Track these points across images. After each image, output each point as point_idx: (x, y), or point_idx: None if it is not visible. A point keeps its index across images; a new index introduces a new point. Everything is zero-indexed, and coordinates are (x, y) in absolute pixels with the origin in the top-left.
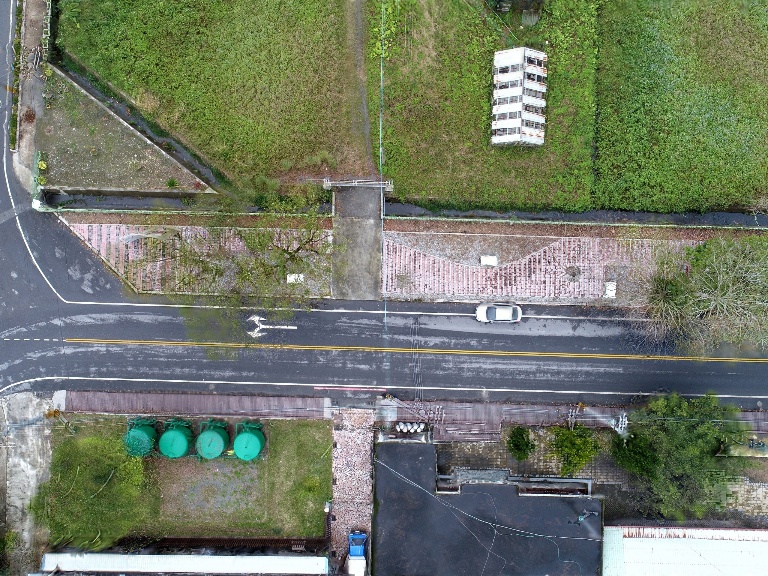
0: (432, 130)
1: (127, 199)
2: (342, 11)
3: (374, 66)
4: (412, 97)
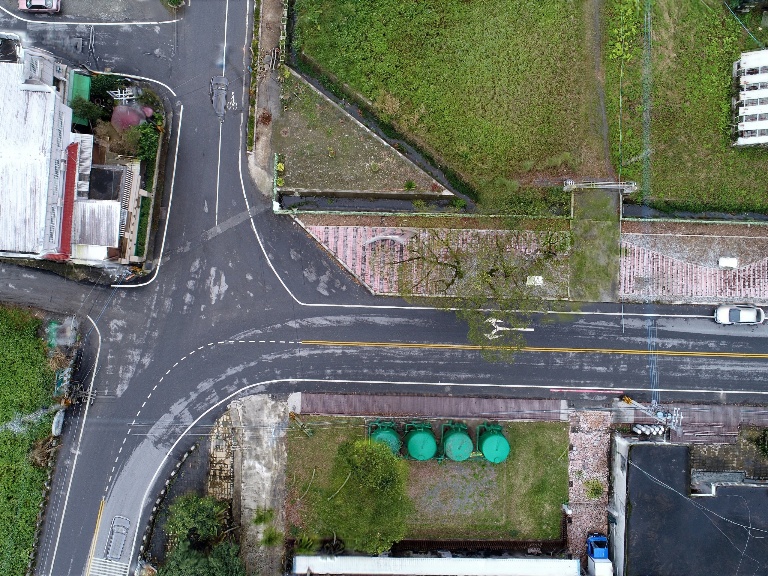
0: (671, 132)
1: (358, 201)
2: (581, 12)
3: (613, 67)
4: (653, 98)
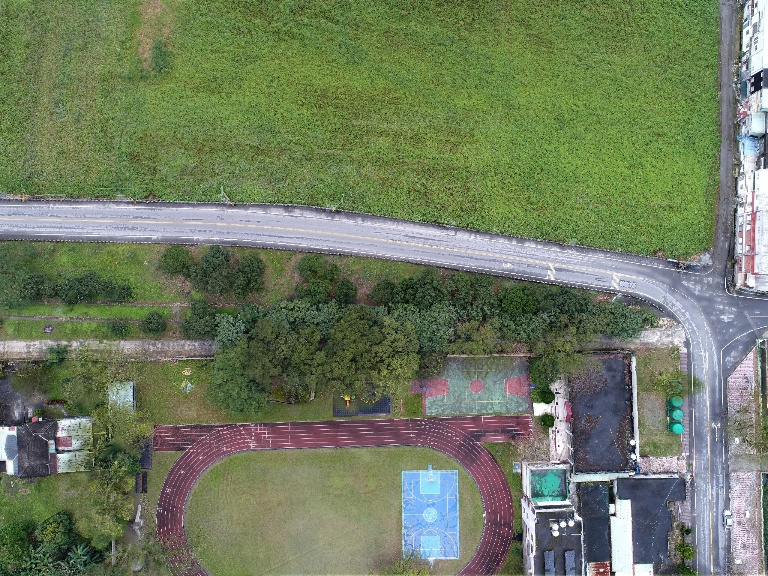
0: None
1: (761, 371)
2: None
3: None
4: None
